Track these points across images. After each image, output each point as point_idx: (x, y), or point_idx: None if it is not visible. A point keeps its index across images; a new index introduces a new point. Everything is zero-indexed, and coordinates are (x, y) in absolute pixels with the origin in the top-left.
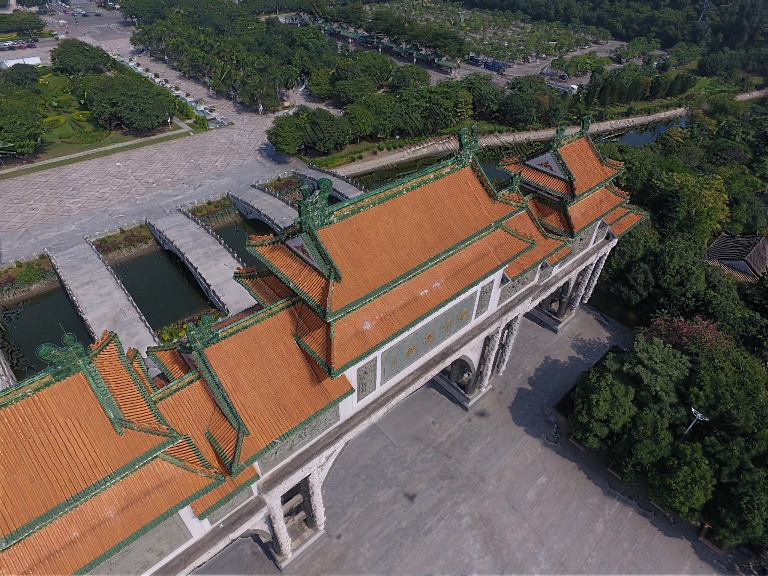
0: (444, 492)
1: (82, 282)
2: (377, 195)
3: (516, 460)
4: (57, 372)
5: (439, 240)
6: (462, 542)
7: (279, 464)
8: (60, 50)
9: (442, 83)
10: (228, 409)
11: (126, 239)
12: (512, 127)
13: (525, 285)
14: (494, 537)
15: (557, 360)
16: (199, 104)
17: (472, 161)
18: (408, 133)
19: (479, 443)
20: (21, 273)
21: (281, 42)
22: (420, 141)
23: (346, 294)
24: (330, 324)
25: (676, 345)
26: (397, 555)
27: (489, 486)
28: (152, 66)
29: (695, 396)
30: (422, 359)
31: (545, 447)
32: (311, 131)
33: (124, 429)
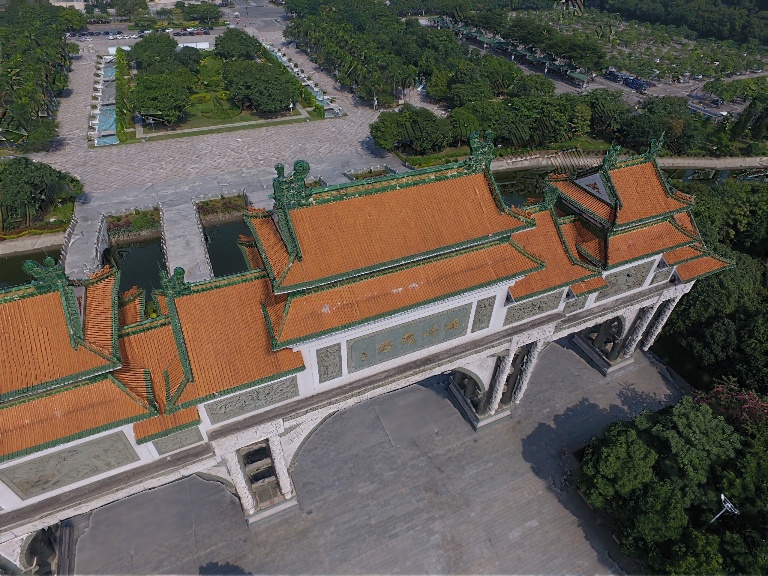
0: (424, 503)
1: (176, 235)
2: (364, 186)
3: (511, 495)
4: (40, 286)
5: (422, 241)
6: (424, 557)
7: (230, 419)
8: (223, 37)
9: (561, 95)
10: (183, 355)
11: (224, 205)
12: (633, 150)
13: (544, 311)
14: (459, 564)
15: (595, 405)
16: (319, 94)
17: (485, 168)
18: (512, 143)
19: (477, 466)
20: (136, 219)
21: (413, 43)
22: (523, 153)
23: (304, 273)
24: (287, 299)
25: (736, 421)
26: (356, 548)
27: (472, 512)
28: (295, 57)
29: (729, 482)
30: (401, 359)
31: (548, 491)
32: (410, 129)
33: (80, 346)
